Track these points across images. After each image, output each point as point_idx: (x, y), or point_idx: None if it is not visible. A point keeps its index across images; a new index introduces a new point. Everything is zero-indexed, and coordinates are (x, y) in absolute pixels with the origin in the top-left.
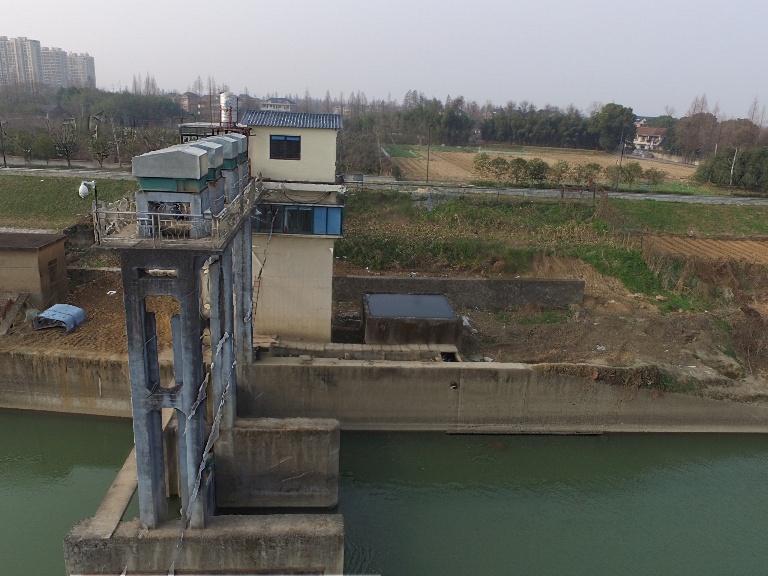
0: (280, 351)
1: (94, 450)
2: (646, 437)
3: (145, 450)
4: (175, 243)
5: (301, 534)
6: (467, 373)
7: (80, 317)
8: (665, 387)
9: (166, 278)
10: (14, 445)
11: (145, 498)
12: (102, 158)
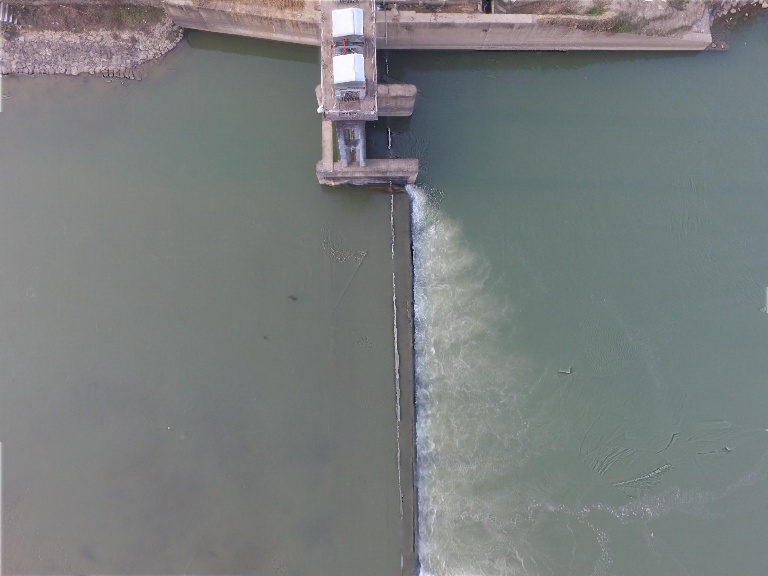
0: (378, 1)
1: (275, 53)
2: (594, 52)
3: (344, 155)
4: (355, 109)
5: (402, 170)
6: (494, 25)
7: None
8: (618, 30)
9: (353, 124)
10: (229, 47)
11: (344, 162)
12: None
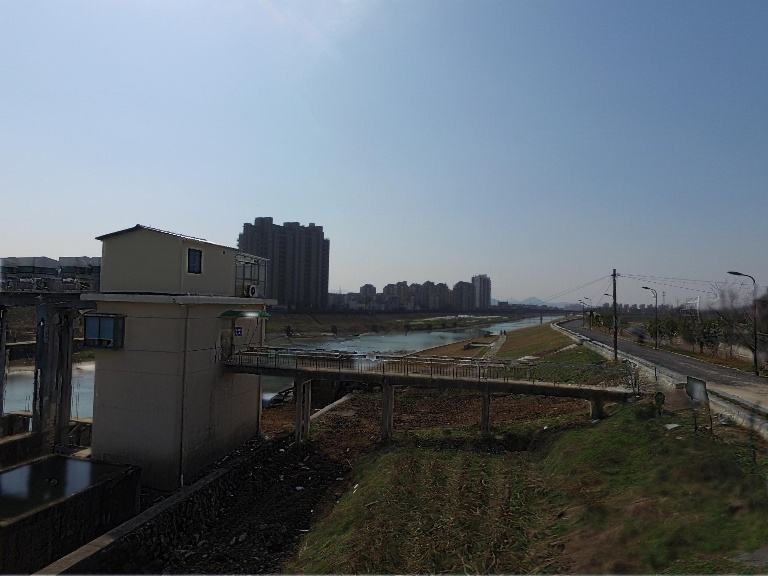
0: None
1: None
2: None
3: None
4: None
5: None
6: None
7: (266, 403)
8: None
9: None
10: None
11: None
12: (711, 345)
